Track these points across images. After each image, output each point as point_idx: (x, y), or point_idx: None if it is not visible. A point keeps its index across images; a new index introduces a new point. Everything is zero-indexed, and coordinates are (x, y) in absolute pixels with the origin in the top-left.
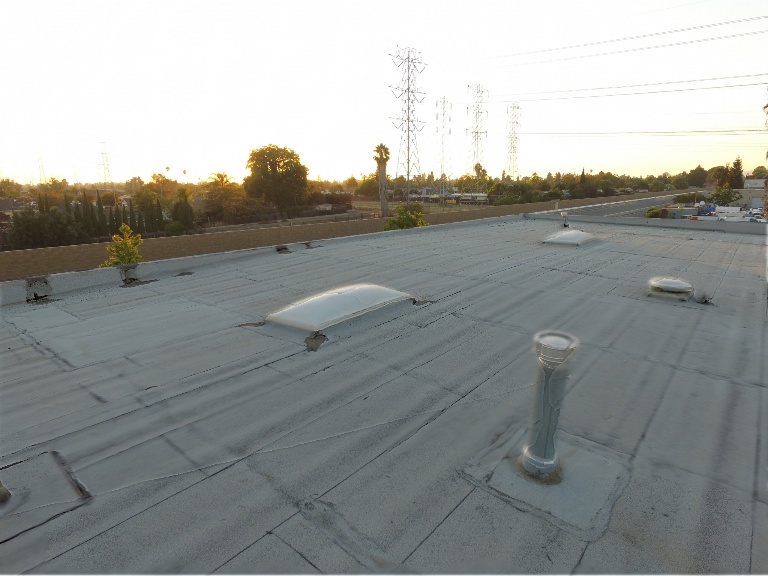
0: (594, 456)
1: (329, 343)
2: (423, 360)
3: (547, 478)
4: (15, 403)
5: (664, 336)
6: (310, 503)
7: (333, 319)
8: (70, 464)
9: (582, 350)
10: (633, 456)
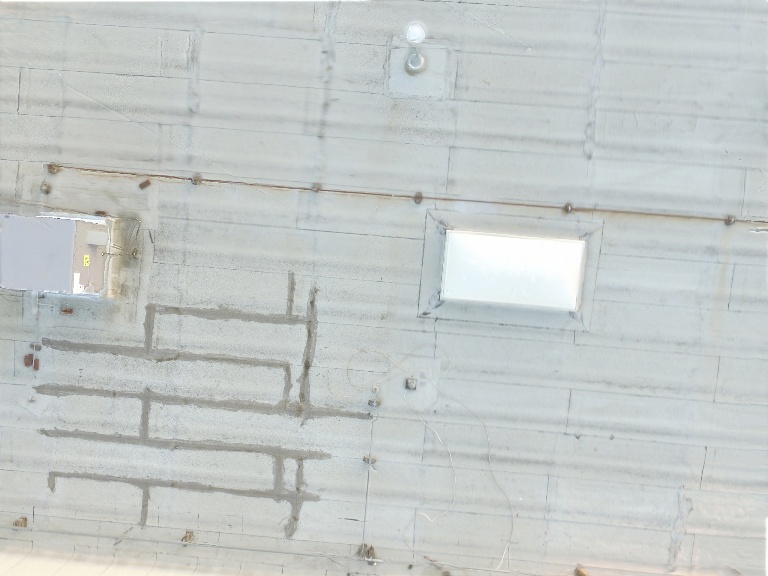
0: (442, 84)
1: None
2: None
3: (408, 70)
4: None
5: (659, 94)
6: None
7: None
8: None
9: (585, 44)
10: (453, 99)
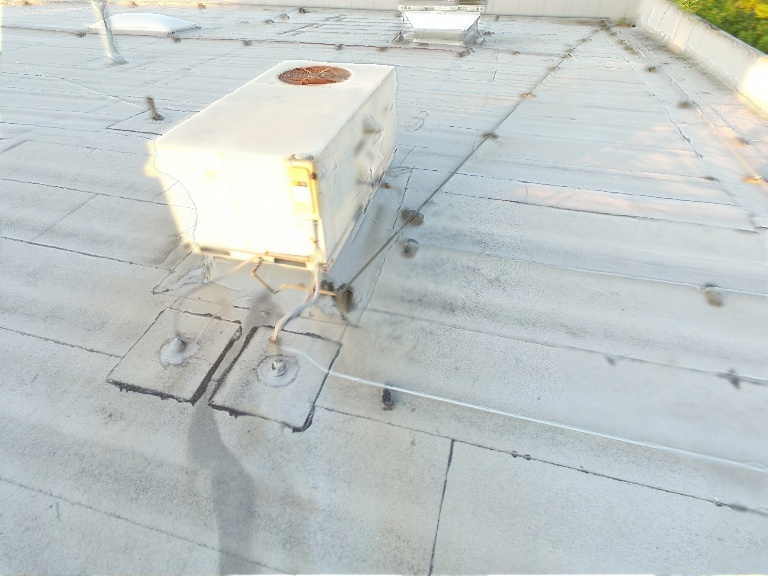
0: None
1: None
2: None
3: (126, 61)
4: (4, 182)
5: None
6: (147, 83)
7: None
8: (121, 121)
9: None
10: None
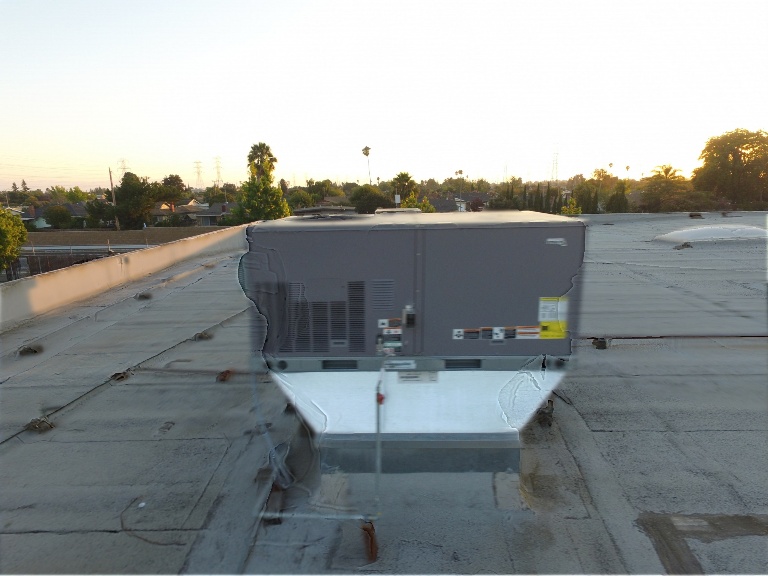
0: None
1: (692, 248)
2: (759, 260)
3: None
4: None
5: None
6: None
7: (701, 238)
8: None
9: None
10: None
